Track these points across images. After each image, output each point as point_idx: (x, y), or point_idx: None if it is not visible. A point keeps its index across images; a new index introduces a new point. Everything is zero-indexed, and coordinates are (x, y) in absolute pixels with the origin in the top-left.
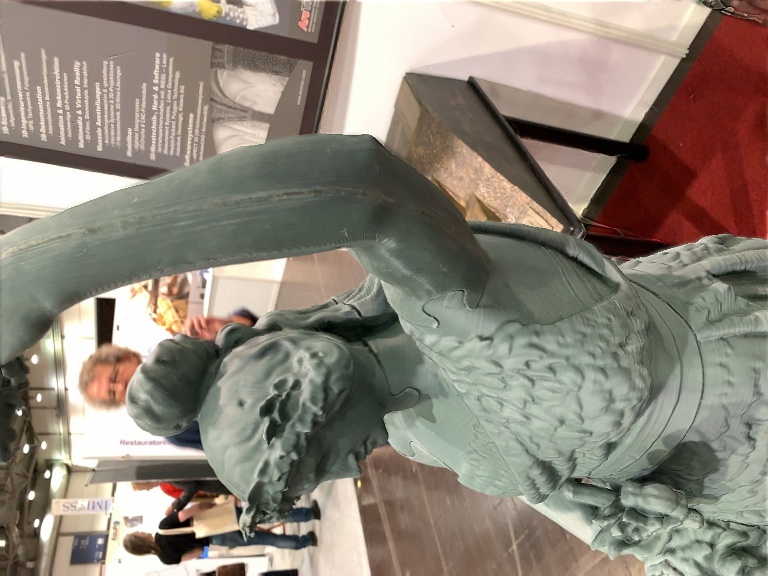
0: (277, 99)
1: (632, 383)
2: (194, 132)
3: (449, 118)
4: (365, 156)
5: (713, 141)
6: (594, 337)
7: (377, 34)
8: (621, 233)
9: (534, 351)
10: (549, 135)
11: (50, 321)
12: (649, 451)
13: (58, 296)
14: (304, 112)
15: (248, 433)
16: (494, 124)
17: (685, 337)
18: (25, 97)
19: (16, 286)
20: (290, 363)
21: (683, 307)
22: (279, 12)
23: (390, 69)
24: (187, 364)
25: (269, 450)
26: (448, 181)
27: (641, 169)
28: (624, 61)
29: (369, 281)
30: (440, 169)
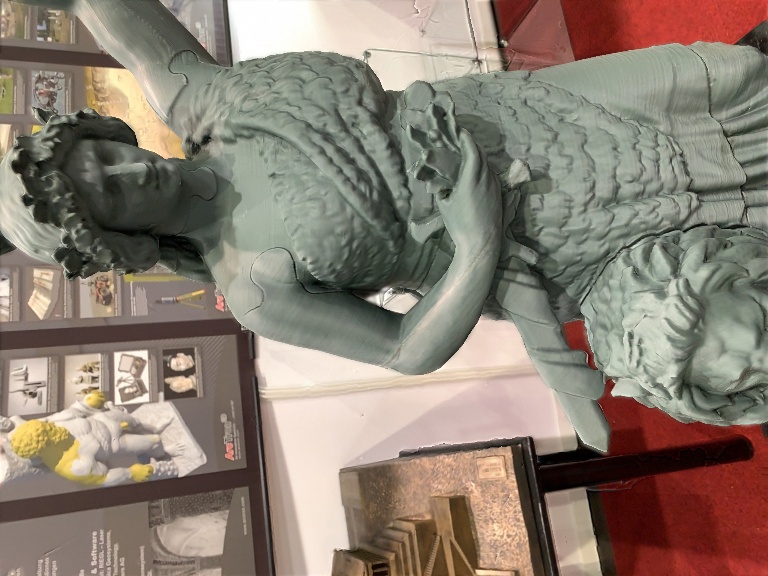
0: (223, 537)
1: None
2: None
3: None
4: None
5: None
6: None
7: (299, 443)
8: None
9: None
10: None
11: None
12: None
13: None
14: (254, 541)
15: None
16: None
17: None
18: None
19: None
20: None
21: None
22: (205, 453)
23: (325, 474)
24: None
25: None
26: (406, 509)
27: None
28: (521, 391)
29: None
30: (395, 506)
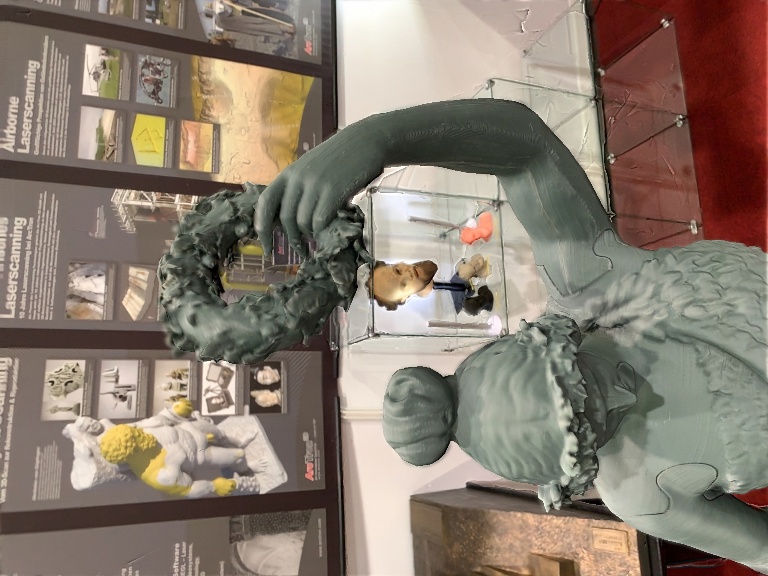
0: (299, 557)
1: None
2: None
3: (470, 504)
4: None
5: None
6: None
7: (374, 467)
8: None
9: (691, 253)
10: None
11: (380, 172)
12: None
13: (394, 130)
14: (328, 563)
15: (520, 357)
16: (511, 498)
17: None
18: None
19: (368, 127)
20: None
21: None
22: (286, 471)
23: (395, 499)
24: None
25: (548, 355)
26: (499, 559)
27: None
28: None
29: None
30: (485, 552)
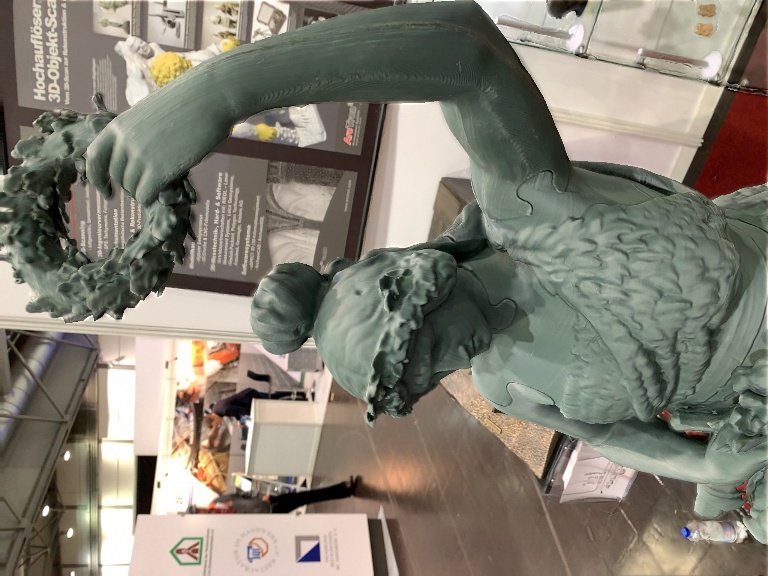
0: (326, 207)
1: (722, 253)
2: (251, 242)
3: None
4: (470, 8)
5: None
6: (677, 212)
7: (413, 145)
8: None
9: (624, 224)
10: None
11: (226, 137)
12: (751, 352)
13: (241, 95)
14: (351, 218)
15: (367, 313)
16: None
17: (763, 238)
18: (103, 220)
19: (210, 87)
20: (398, 265)
21: (754, 219)
22: (326, 131)
23: (427, 176)
24: (304, 274)
25: (389, 323)
26: None
27: None
28: (644, 154)
29: (456, 220)
30: None
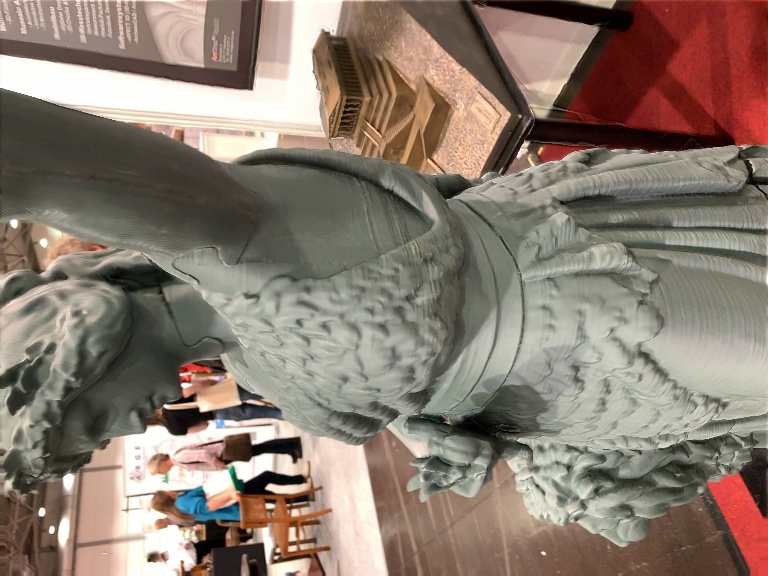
0: None
1: (420, 338)
2: (124, 9)
3: None
4: None
5: (700, 6)
6: (374, 291)
7: None
8: (581, 117)
9: (304, 309)
10: (521, 2)
11: None
12: (472, 394)
13: None
14: None
15: (0, 400)
16: None
17: (508, 277)
18: None
19: None
20: (54, 321)
21: (515, 242)
22: None
23: None
24: None
25: (21, 418)
26: (398, 62)
27: (623, 39)
28: None
29: None
30: (390, 48)
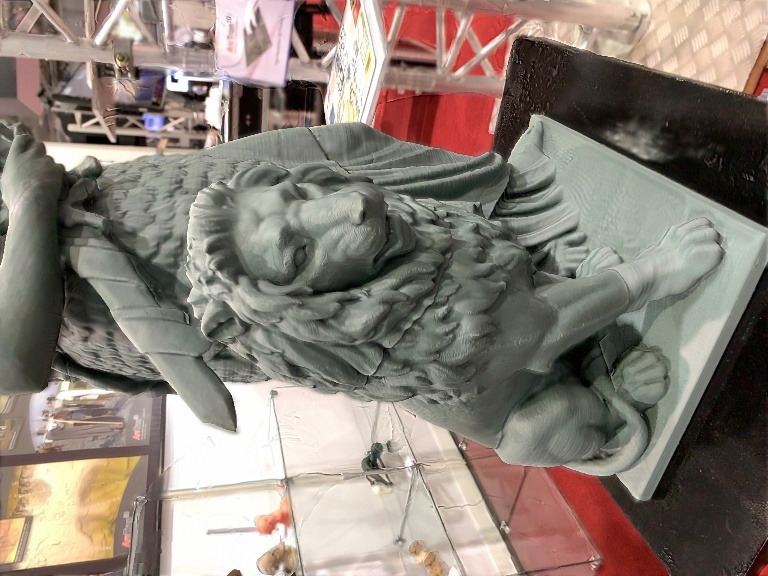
0: None
1: None
2: None
3: None
4: None
5: None
6: None
7: None
8: None
9: None
10: None
11: None
12: None
13: None
14: None
15: None
16: None
17: None
18: None
19: None
20: None
21: None
22: None
23: None
24: None
25: None
26: None
27: None
28: None
29: None
30: None
